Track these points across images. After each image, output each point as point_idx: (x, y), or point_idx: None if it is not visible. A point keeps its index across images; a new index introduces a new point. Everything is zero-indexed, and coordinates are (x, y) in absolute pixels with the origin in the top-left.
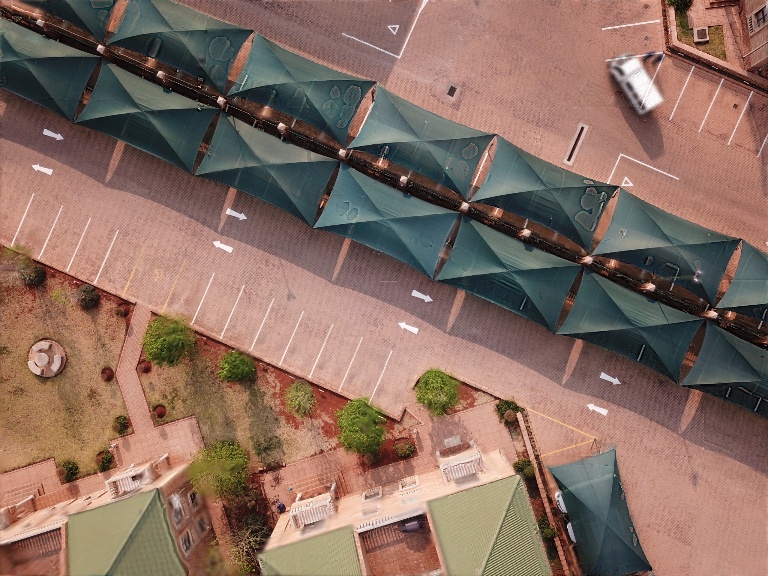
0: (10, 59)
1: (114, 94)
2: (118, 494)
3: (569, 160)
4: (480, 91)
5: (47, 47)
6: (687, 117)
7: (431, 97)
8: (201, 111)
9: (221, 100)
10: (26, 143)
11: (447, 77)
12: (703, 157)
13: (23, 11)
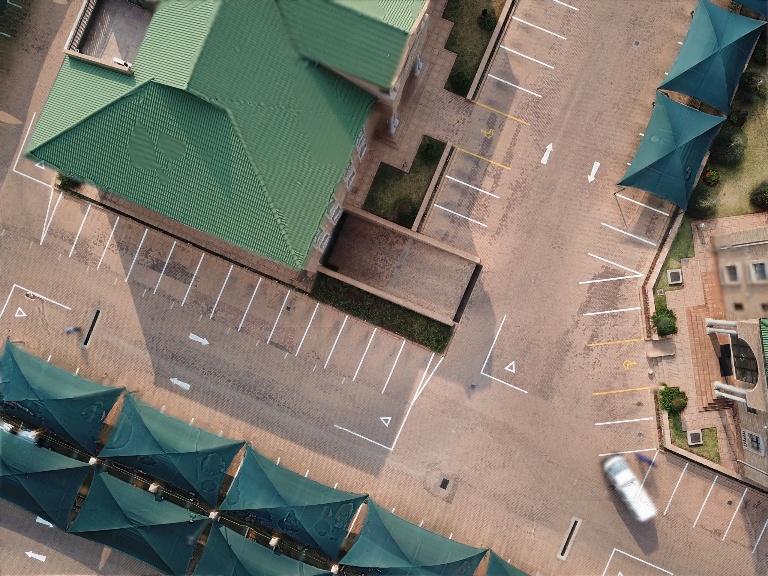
0: (2, 474)
1: (106, 505)
2: None
3: (563, 554)
4: (473, 484)
5: (39, 459)
6: (681, 512)
7: (424, 490)
8: (193, 523)
9: (213, 516)
10: (19, 530)
11: (440, 470)
12: (697, 552)
13: (16, 404)
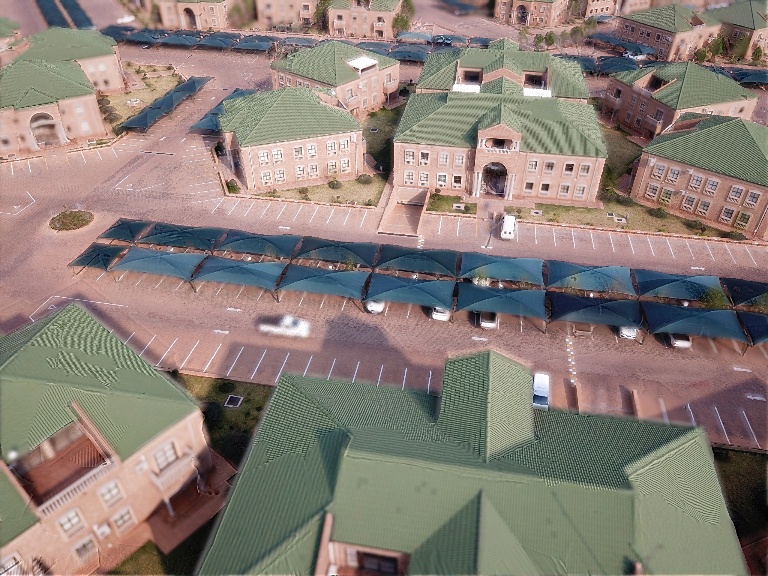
0: None
1: None
2: (760, 38)
3: None
4: None
5: None
6: None
7: None
8: None
9: None
10: None
11: None
12: None
13: None
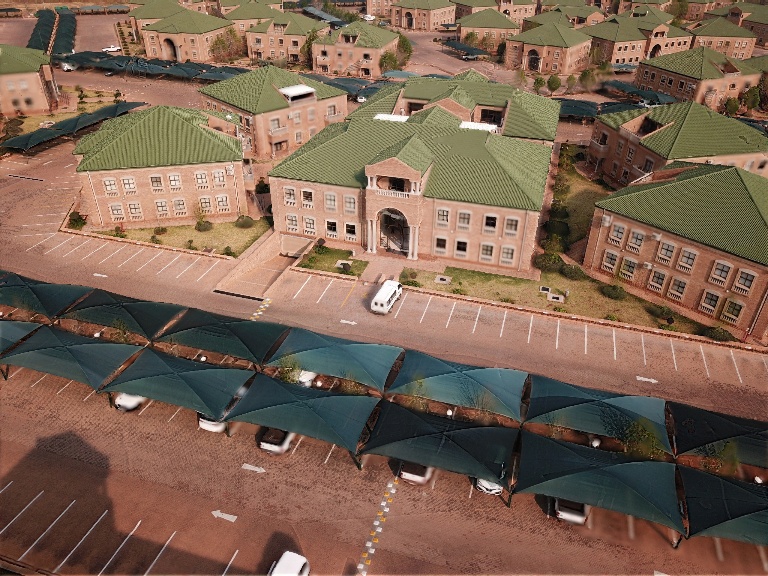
0: None
1: None
2: None
3: None
4: None
5: None
6: None
7: None
8: None
9: None
10: None
11: None
12: None
13: None
